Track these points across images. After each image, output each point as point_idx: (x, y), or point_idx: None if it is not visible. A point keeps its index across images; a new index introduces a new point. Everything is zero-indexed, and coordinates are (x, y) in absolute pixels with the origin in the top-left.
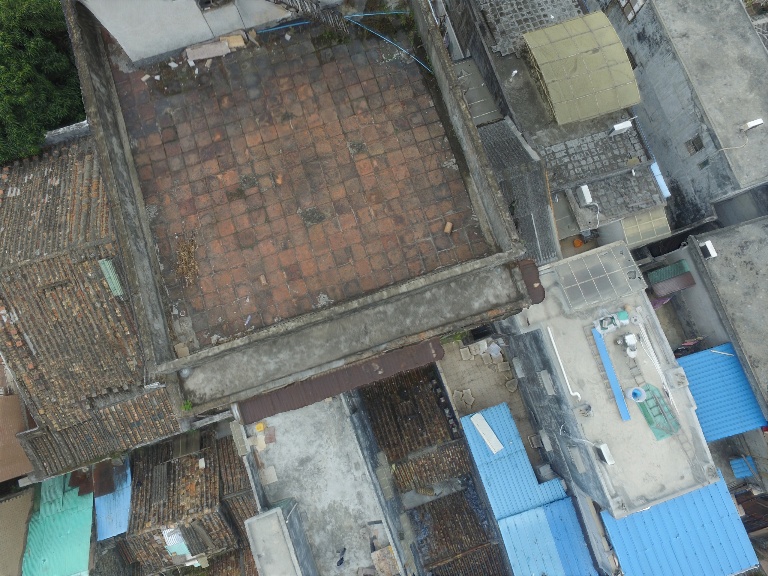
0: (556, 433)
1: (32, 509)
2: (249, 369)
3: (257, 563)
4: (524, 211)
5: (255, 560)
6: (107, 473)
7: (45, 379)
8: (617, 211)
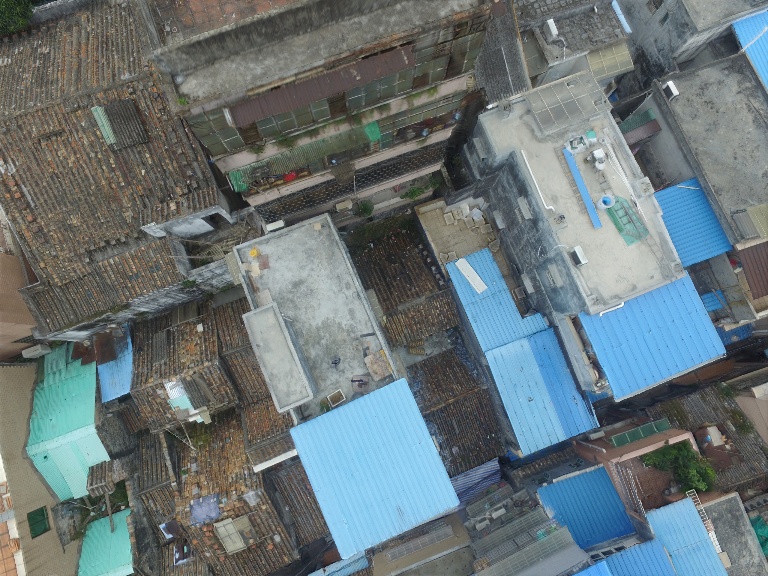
0: (536, 267)
1: (36, 380)
2: (238, 74)
3: (256, 351)
4: (494, 45)
5: (254, 348)
6: (108, 343)
7: (44, 232)
8: (582, 46)
